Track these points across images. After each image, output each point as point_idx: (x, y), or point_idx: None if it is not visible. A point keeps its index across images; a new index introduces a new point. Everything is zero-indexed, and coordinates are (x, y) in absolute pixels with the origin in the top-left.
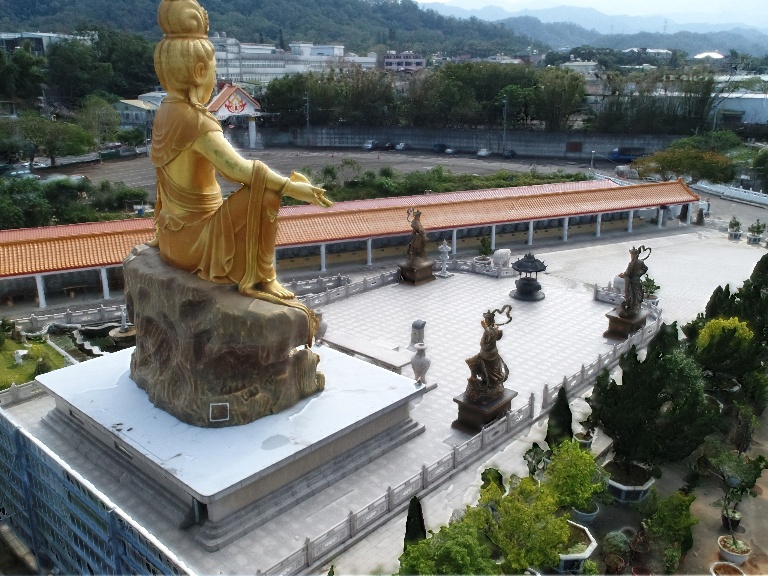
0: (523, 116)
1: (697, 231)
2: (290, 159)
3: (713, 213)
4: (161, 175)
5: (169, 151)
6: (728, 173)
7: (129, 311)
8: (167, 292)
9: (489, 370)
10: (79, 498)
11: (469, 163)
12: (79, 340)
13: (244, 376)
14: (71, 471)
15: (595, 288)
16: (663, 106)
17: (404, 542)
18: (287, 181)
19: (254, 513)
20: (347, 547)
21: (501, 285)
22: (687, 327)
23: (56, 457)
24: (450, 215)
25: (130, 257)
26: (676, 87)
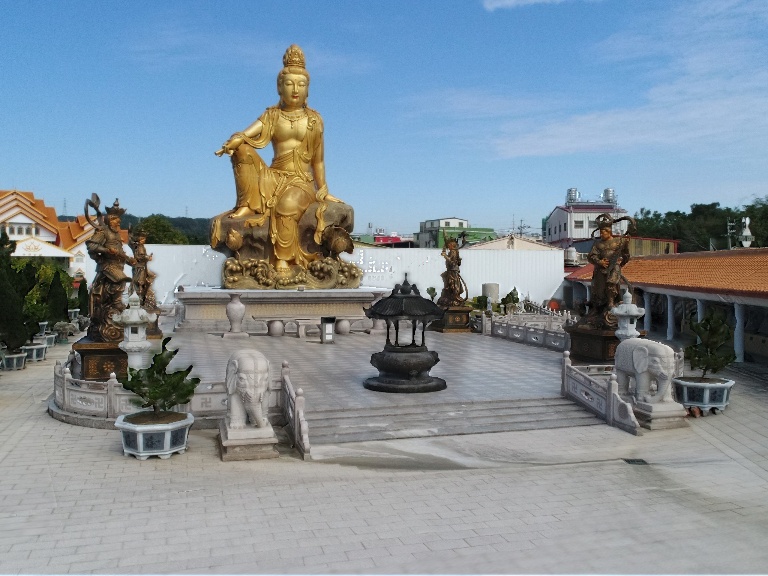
0: None
1: None
2: None
3: None
4: None
5: None
6: None
7: None
8: None
9: None
10: None
11: None
12: None
13: None
14: None
15: None
16: None
17: None
18: None
19: None
20: None
21: None
22: None
23: None
24: None
25: None
26: None
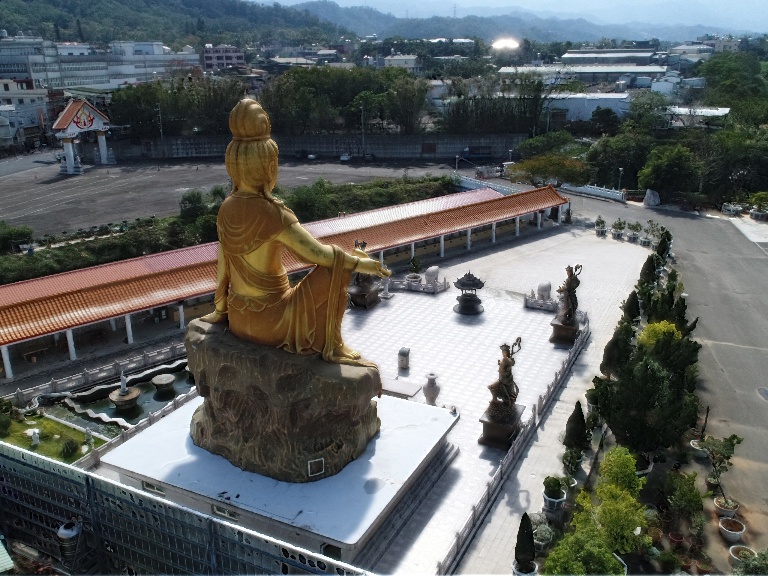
0: (379, 120)
1: (570, 230)
2: (154, 175)
3: (573, 210)
4: (238, 263)
5: (251, 242)
6: (585, 177)
7: (201, 386)
8: (261, 369)
9: (508, 392)
10: (306, 569)
11: (337, 169)
12: (78, 409)
13: (330, 432)
14: (297, 548)
15: (525, 297)
16: (502, 107)
17: (516, 550)
18: (358, 260)
19: (373, 549)
20: (458, 562)
21: (441, 301)
22: (622, 329)
23: (272, 539)
24: (376, 238)
25: (199, 336)
26: (512, 90)
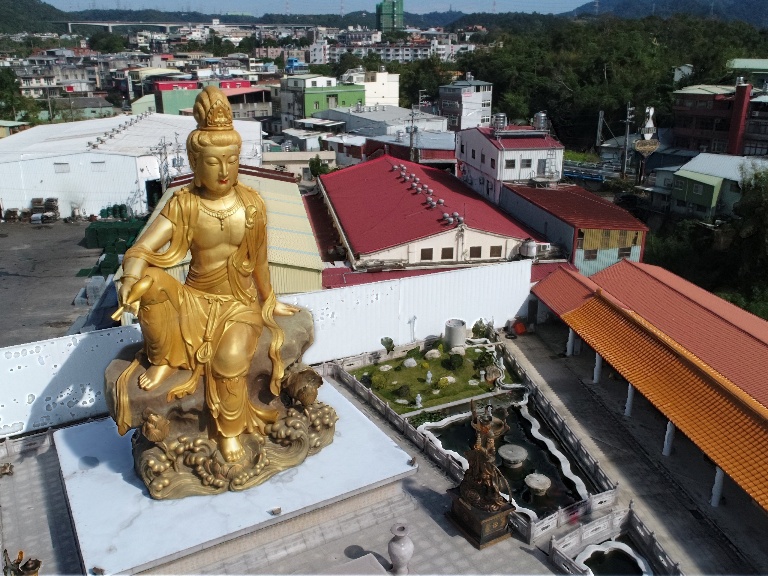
0: None
1: None
2: None
3: None
4: None
5: None
6: None
7: None
8: None
9: None
10: None
11: None
12: None
13: None
14: None
15: None
16: None
17: None
18: None
19: None
20: None
21: None
22: None
23: None
24: None
25: None
26: None
